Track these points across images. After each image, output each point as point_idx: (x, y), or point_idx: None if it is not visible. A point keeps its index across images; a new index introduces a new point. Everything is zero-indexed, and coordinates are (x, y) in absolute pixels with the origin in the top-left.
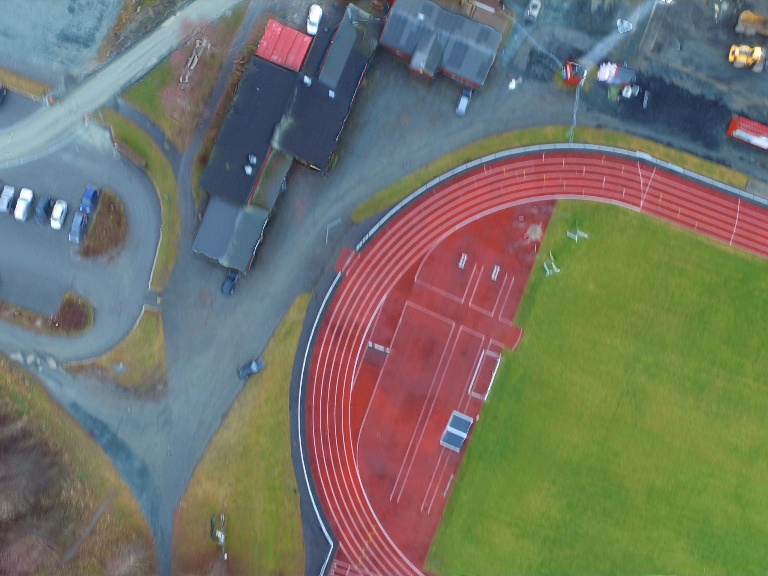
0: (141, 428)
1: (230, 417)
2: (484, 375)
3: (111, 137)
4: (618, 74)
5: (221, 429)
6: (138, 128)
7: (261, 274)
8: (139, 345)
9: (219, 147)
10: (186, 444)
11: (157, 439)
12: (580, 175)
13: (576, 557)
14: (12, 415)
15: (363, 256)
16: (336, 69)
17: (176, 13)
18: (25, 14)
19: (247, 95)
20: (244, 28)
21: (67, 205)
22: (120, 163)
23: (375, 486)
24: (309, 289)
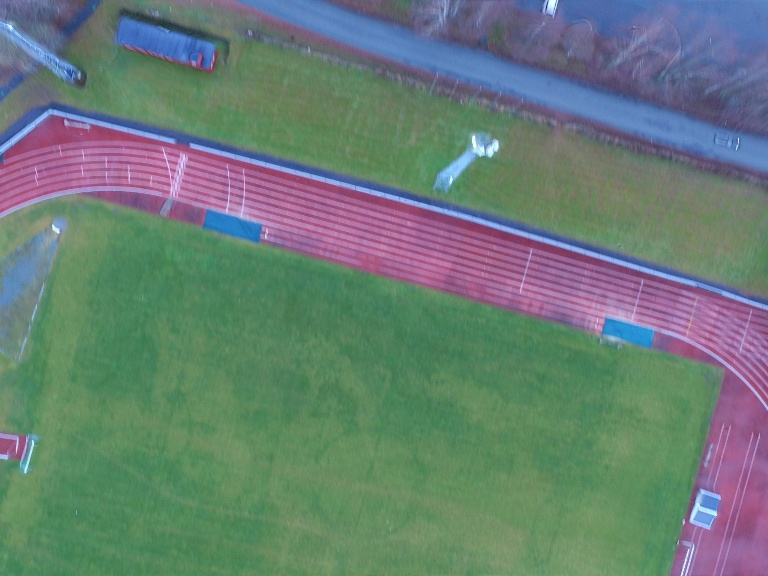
0: None
1: None
2: None
3: None
4: None
5: None
6: None
7: None
8: None
9: None
10: None
11: None
12: None
13: (579, 395)
14: None
15: None
16: None
17: None
18: None
19: None
20: None
21: None
22: None
23: None
24: None
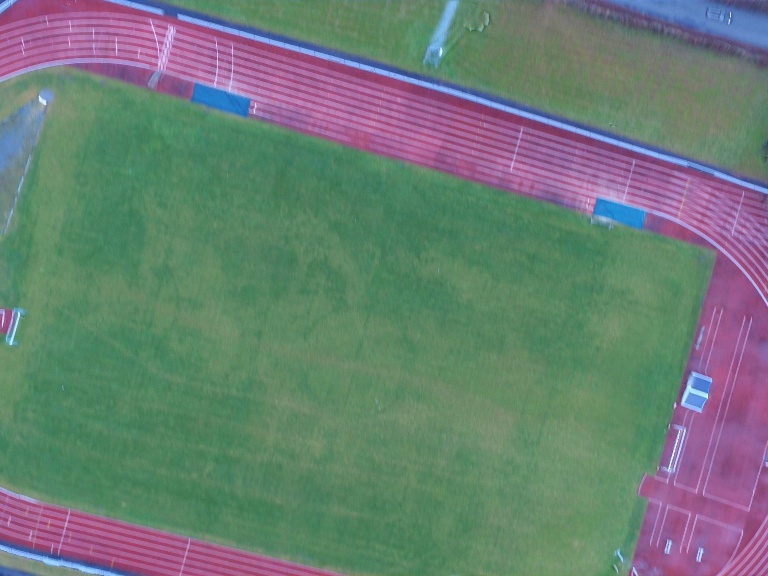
0: None
1: None
2: None
3: None
4: None
5: None
6: None
7: None
8: None
9: None
10: None
11: None
12: None
13: (570, 275)
14: None
15: None
16: None
17: None
18: None
19: None
20: None
21: None
22: None
23: None
24: None
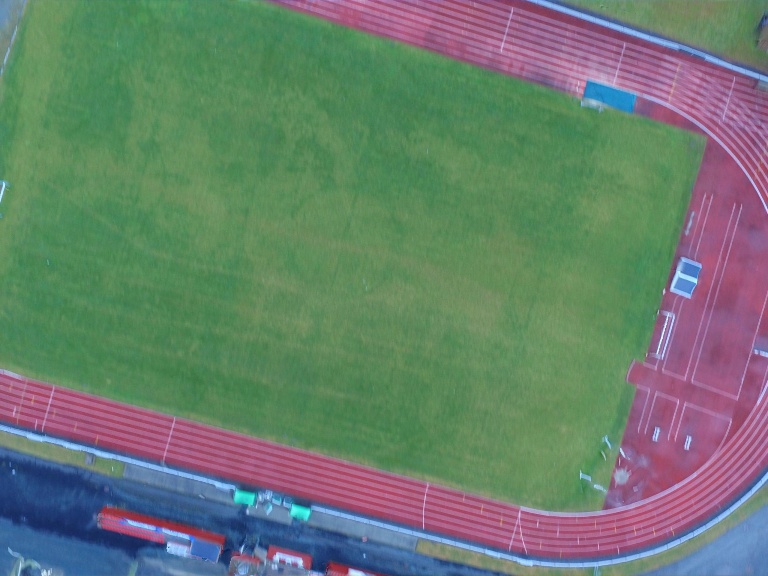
0: None
1: None
2: None
3: None
4: None
5: None
6: None
7: None
8: None
9: None
10: None
11: None
12: (582, 536)
13: (559, 158)
14: None
15: None
16: None
17: None
18: None
19: None
20: None
21: None
22: None
23: (759, 218)
24: None
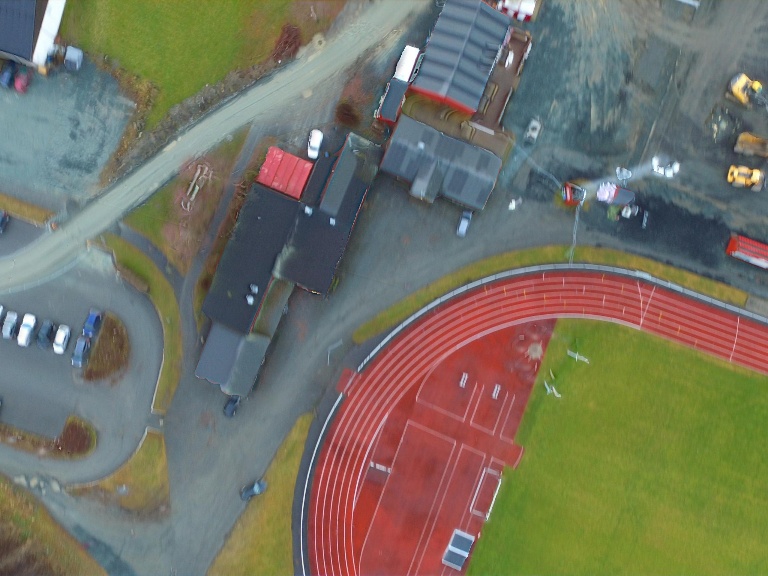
0: (144, 550)
1: (233, 538)
2: (485, 493)
3: (113, 261)
4: (617, 196)
5: (224, 550)
6: (140, 252)
7: (263, 395)
8: (142, 467)
9: (221, 274)
10: (189, 565)
11: (160, 560)
12: (580, 294)
13: None
14: (16, 539)
15: (364, 376)
16: (337, 197)
17: (177, 138)
18: (27, 141)
19: (248, 222)
20: (245, 152)
21: (70, 329)
22: (122, 287)
23: None
24: (311, 409)
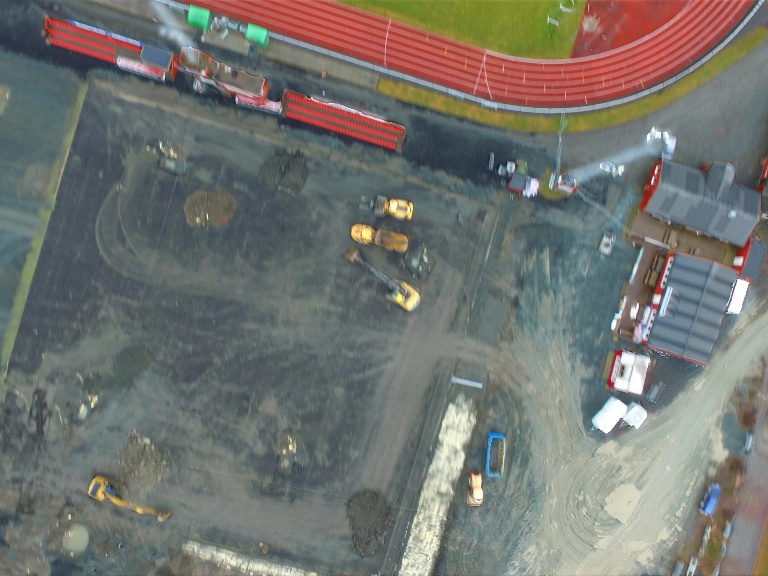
0: None
1: None
2: None
3: None
4: None
5: None
6: None
7: None
8: None
9: None
10: None
11: None
12: (549, 84)
13: None
14: None
15: None
16: None
17: None
18: None
19: None
20: None
21: None
22: None
23: None
24: None
